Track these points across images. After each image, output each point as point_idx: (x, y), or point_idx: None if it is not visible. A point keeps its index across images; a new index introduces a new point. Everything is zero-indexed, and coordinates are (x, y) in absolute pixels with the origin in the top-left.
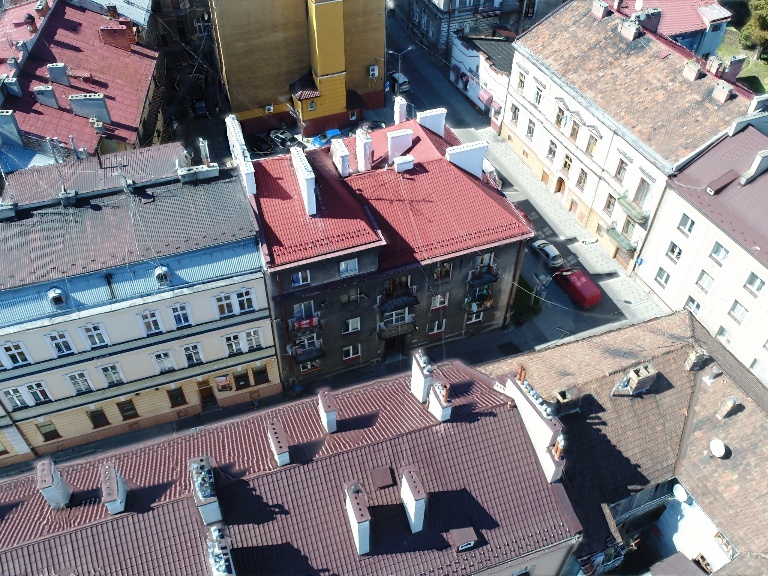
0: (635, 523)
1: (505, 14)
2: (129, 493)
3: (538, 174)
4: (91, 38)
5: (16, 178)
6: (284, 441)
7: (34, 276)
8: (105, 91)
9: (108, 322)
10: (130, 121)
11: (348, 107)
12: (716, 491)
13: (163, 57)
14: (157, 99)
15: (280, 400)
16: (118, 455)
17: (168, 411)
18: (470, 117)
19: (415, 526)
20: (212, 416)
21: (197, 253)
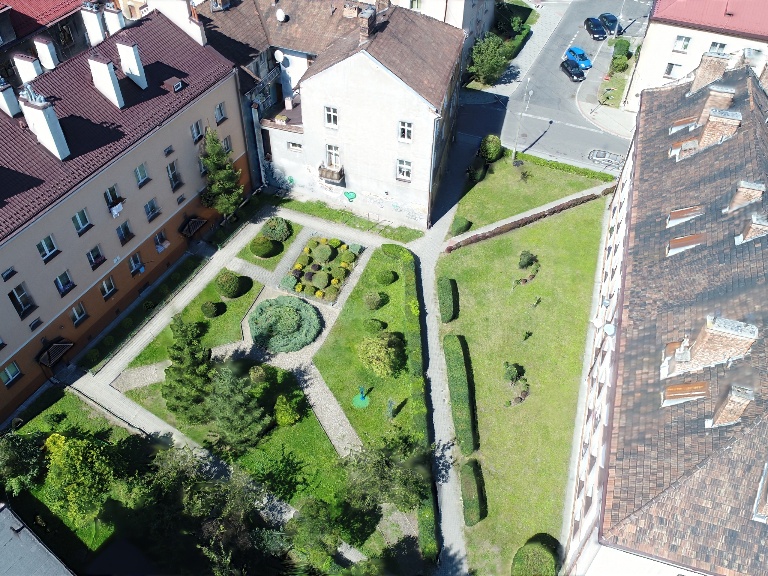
0: None
1: None
2: None
3: None
4: None
5: None
6: None
7: None
8: None
9: None
10: None
11: None
12: (293, 38)
13: None
14: None
15: None
16: None
17: None
18: None
19: (142, 81)
20: None
21: None
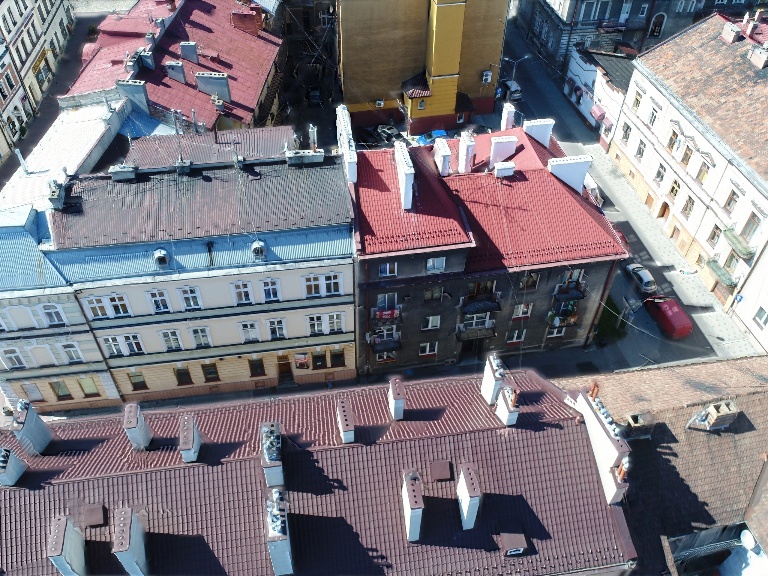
0: (695, 563)
1: (630, 31)
2: (203, 445)
3: (642, 196)
4: (223, 21)
5: (140, 144)
6: (351, 420)
7: (144, 235)
8: (229, 71)
9: (204, 287)
10: (248, 102)
11: (457, 109)
12: None
13: (286, 45)
14: (275, 84)
15: (353, 385)
16: (197, 411)
17: (247, 380)
18: (579, 132)
19: (467, 523)
20: (287, 391)
21: (293, 232)
